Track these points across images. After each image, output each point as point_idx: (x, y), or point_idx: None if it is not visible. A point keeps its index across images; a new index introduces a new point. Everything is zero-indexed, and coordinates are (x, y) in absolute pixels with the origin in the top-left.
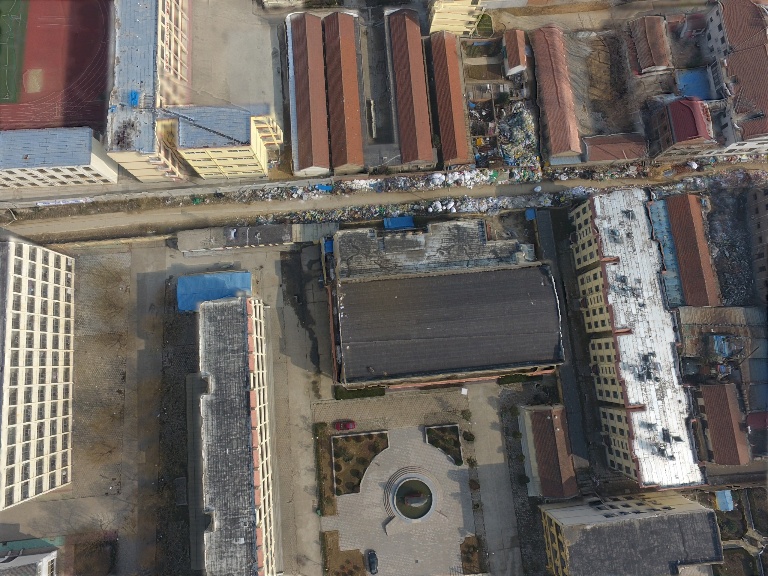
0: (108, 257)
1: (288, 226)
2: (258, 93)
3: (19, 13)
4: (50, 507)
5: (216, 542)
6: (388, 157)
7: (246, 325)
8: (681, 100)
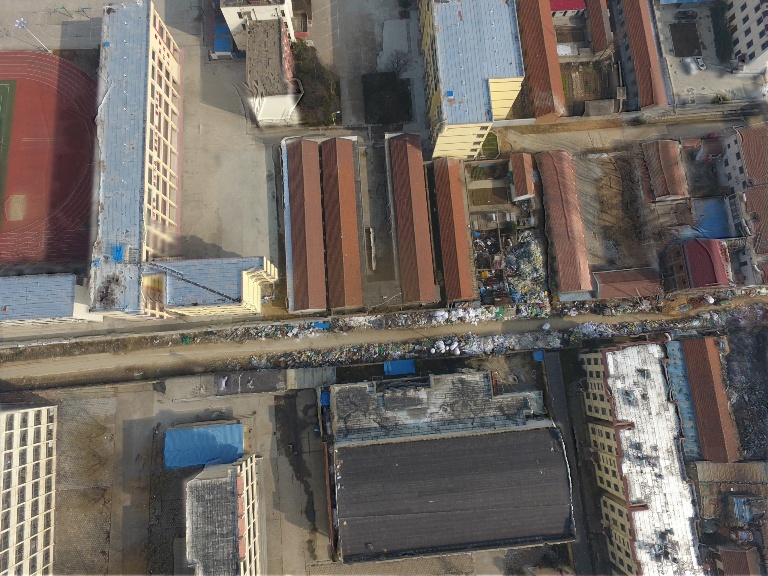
0: (92, 402)
1: (282, 373)
2: (252, 220)
3: (1, 136)
4: None
5: None
6: (388, 296)
7: (236, 505)
8: (698, 238)
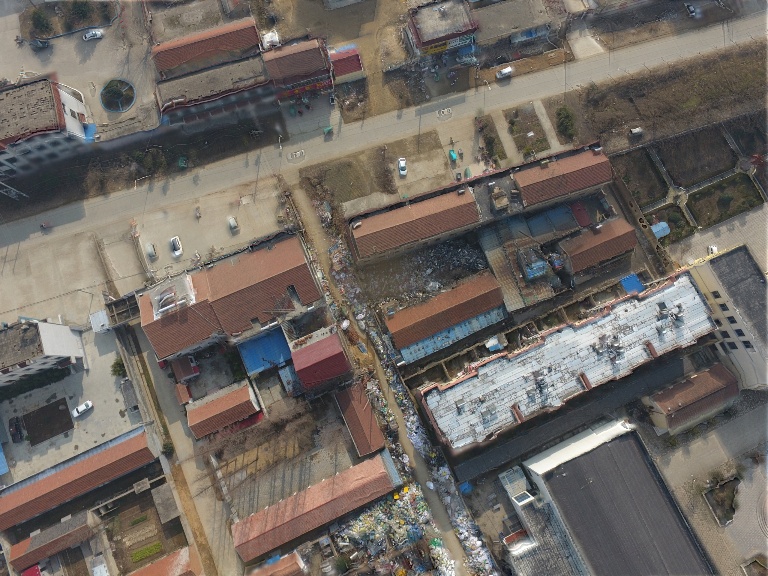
0: None
1: None
2: None
3: None
4: None
5: None
6: None
7: None
8: (295, 370)
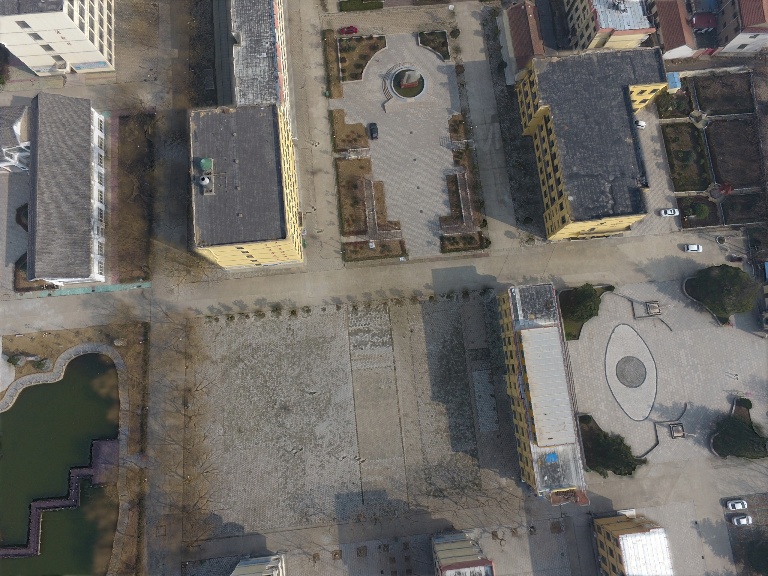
0: None
1: None
2: None
3: None
4: (97, 89)
5: (243, 56)
6: None
7: None
8: None
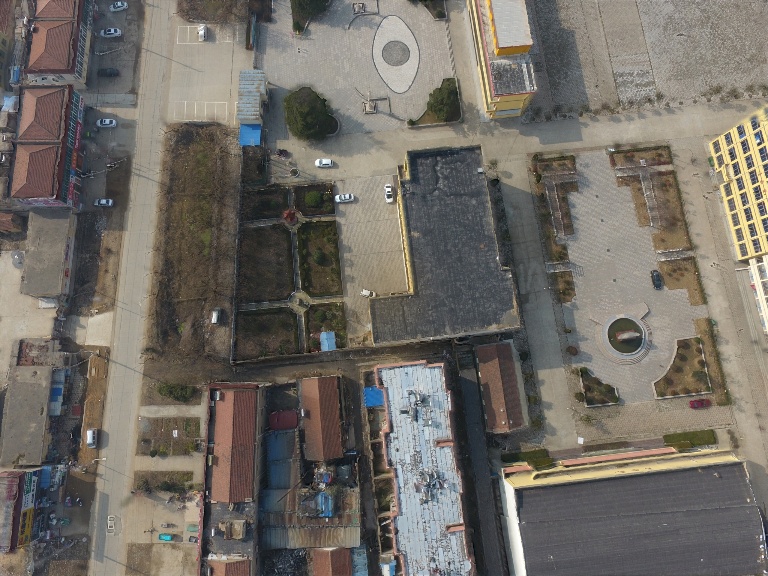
0: None
1: None
2: None
3: None
4: None
5: None
6: None
7: None
8: None
